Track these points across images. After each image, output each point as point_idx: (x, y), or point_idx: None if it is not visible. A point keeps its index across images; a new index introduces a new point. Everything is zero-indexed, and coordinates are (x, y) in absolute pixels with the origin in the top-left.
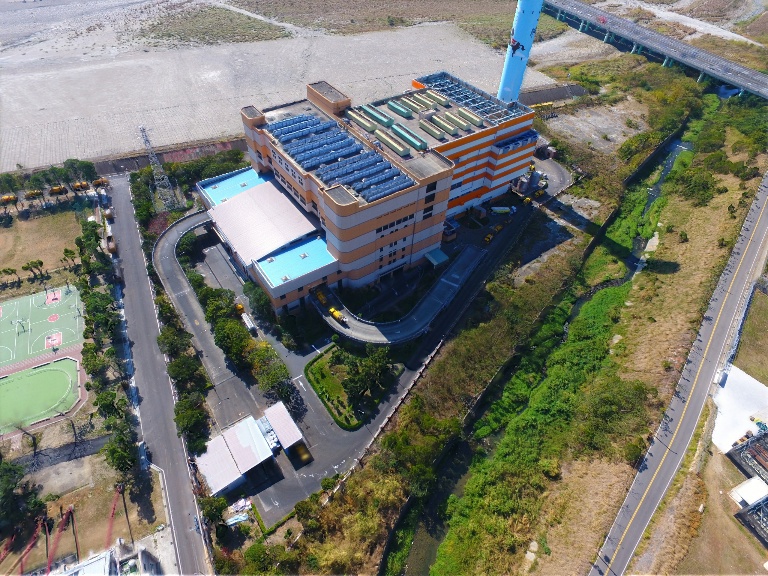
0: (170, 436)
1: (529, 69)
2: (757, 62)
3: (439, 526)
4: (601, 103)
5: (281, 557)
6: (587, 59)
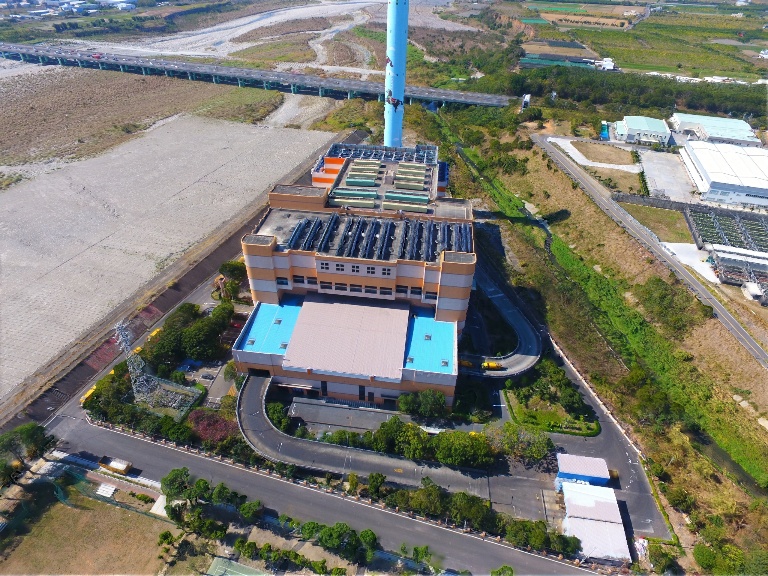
0: (536, 567)
1: (304, 131)
2: (420, 84)
3: (701, 436)
4: None
5: (724, 533)
6: (327, 111)
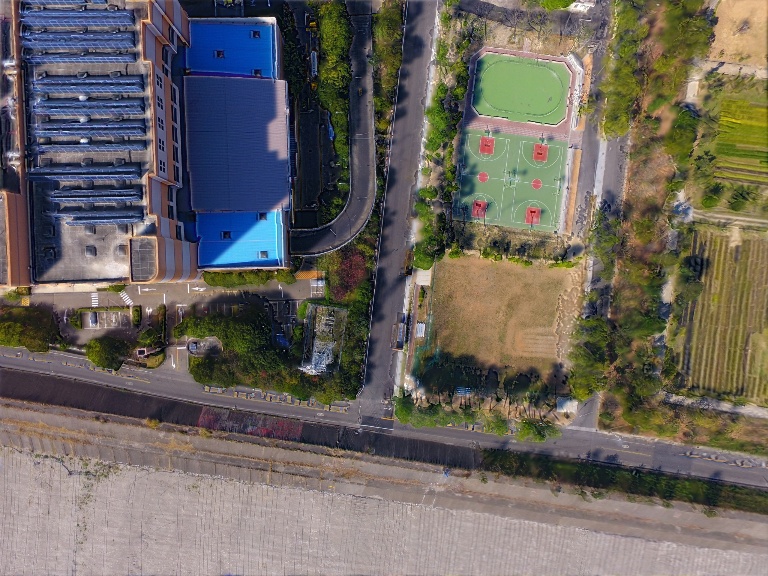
0: None
1: None
2: None
3: None
4: None
5: None
6: None
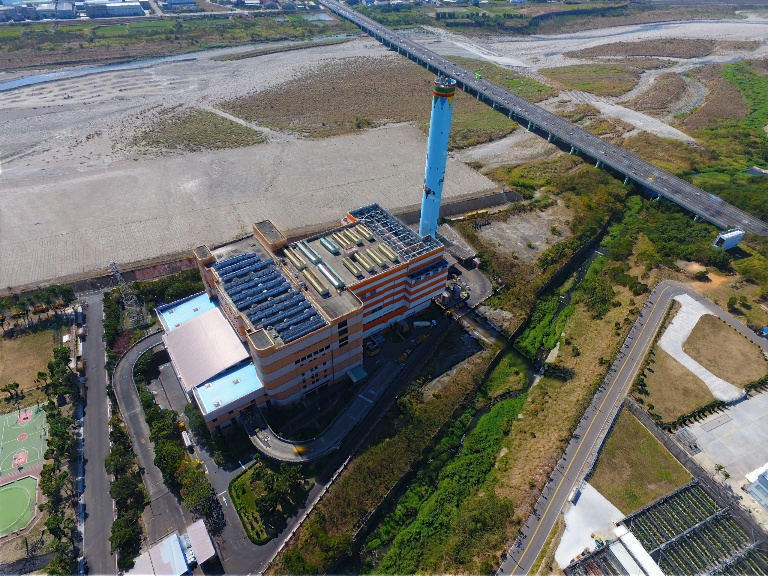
0: (106, 551)
1: (474, 173)
2: (682, 161)
3: None
4: (532, 209)
5: None
6: (530, 160)
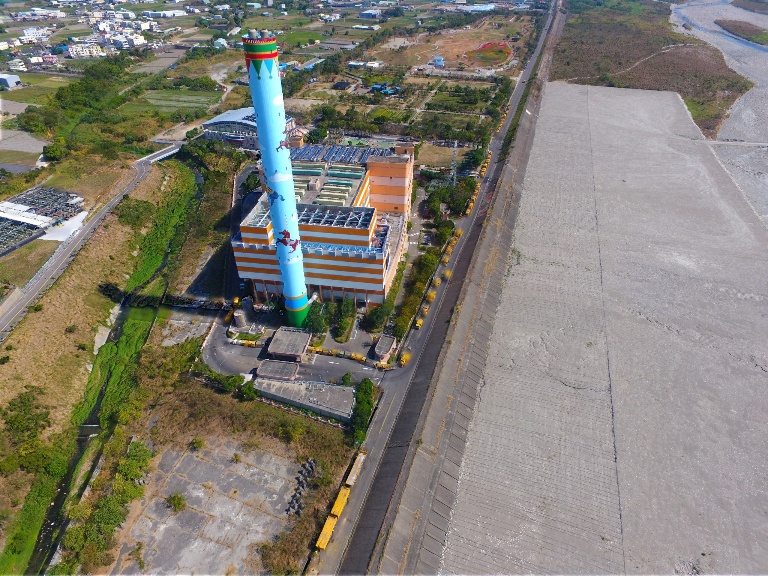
0: None
1: None
2: None
3: None
4: None
5: None
6: None
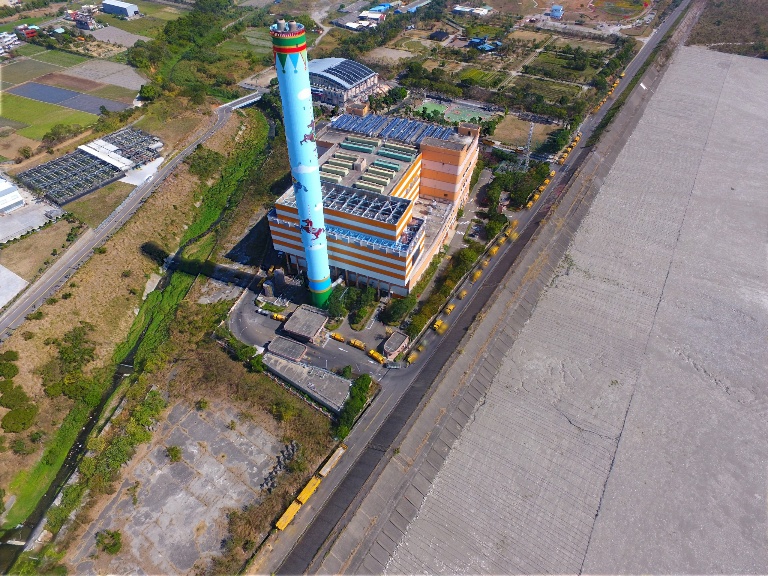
0: None
1: None
2: None
3: None
4: None
5: None
6: None
